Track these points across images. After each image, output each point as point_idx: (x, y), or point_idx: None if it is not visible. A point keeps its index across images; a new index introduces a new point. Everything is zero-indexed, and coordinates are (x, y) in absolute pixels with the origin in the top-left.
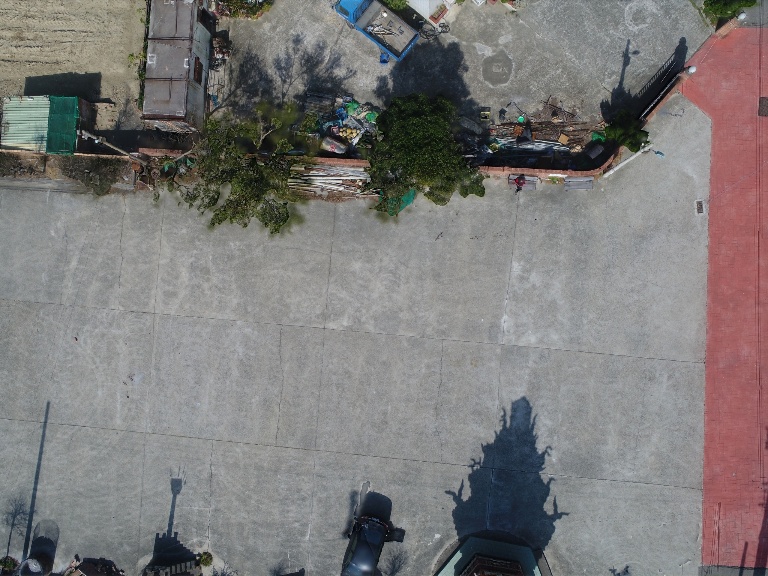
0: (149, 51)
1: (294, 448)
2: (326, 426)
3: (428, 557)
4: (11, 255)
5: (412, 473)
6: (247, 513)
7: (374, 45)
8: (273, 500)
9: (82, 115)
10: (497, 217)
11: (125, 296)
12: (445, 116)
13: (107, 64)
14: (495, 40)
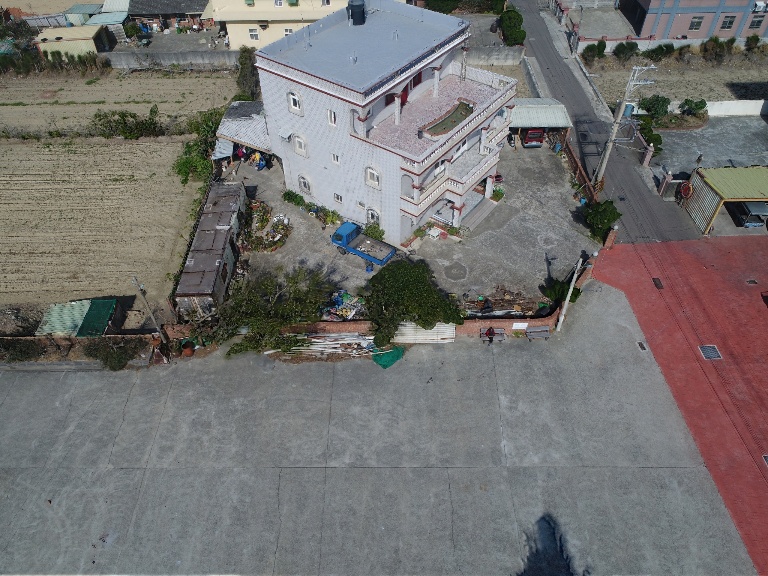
0: (189, 257)
1: None
2: (329, 573)
3: None
4: (6, 426)
5: None
6: None
7: (361, 263)
8: None
9: (116, 313)
10: (477, 363)
11: (117, 454)
12: (423, 271)
13: None
14: (450, 257)
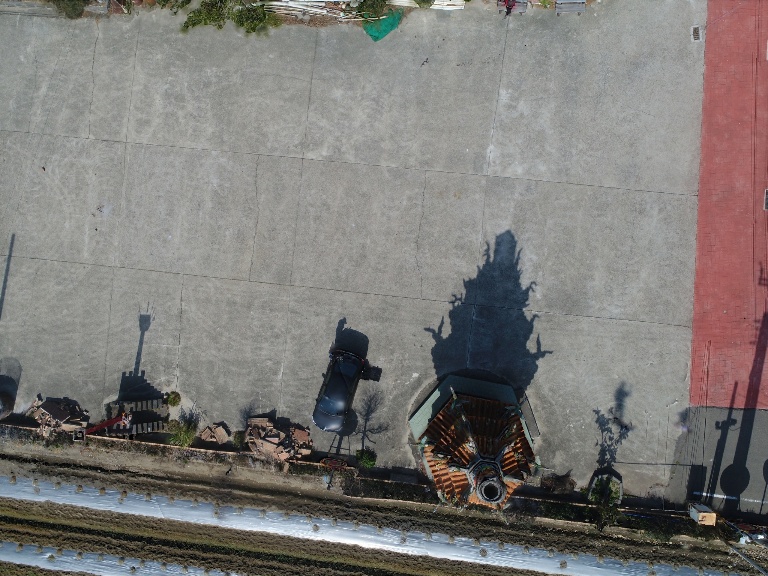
0: None
1: (268, 283)
2: (302, 260)
3: (405, 397)
4: None
5: (390, 309)
6: (218, 351)
7: None
8: (245, 337)
9: None
10: (485, 43)
11: (96, 124)
12: None
13: None
14: None
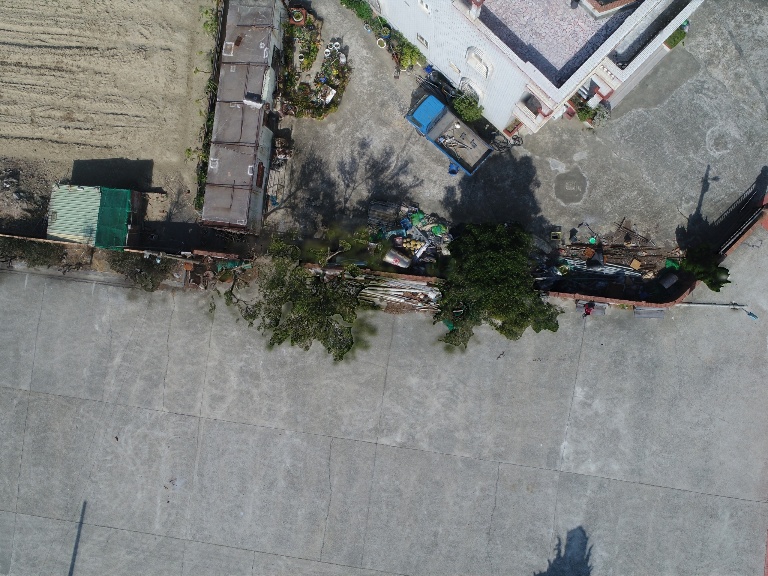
0: (211, 155)
1: (339, 565)
2: (373, 544)
3: None
4: (52, 347)
5: None
6: None
7: (443, 154)
8: None
9: (134, 208)
10: (562, 340)
11: (170, 397)
12: (523, 250)
13: (160, 152)
14: (570, 156)
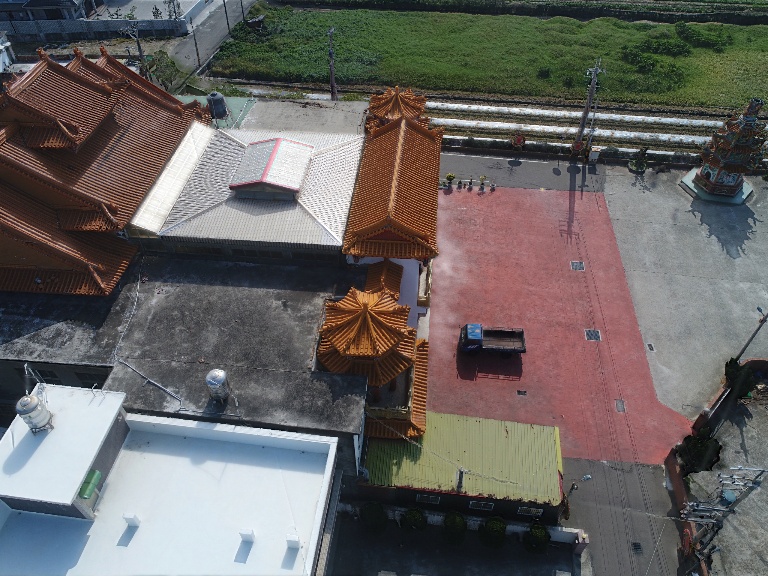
0: None
1: None
2: None
3: (760, 198)
4: None
5: None
6: None
7: None
8: None
9: None
10: None
11: None
12: None
13: None
14: None
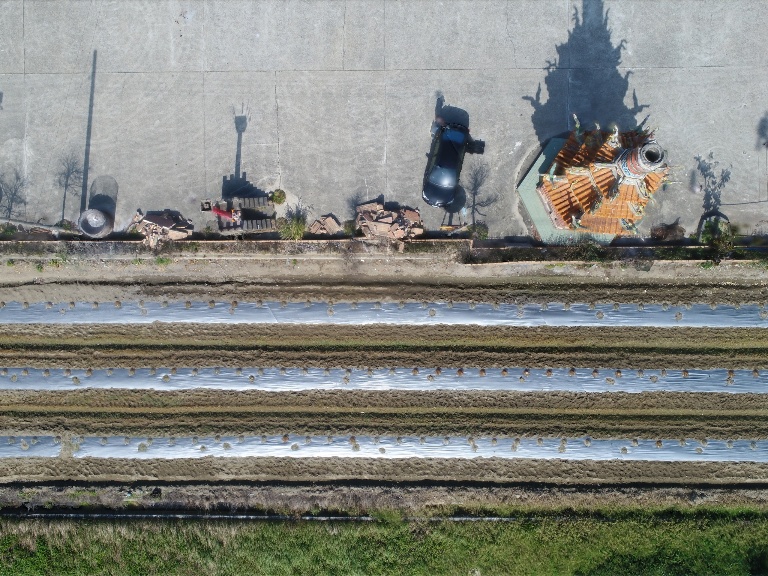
0: None
1: (362, 70)
2: (394, 44)
3: (510, 166)
4: None
5: (487, 82)
6: (318, 143)
7: None
8: (345, 127)
9: None
10: None
11: None
12: None
13: None
14: None
